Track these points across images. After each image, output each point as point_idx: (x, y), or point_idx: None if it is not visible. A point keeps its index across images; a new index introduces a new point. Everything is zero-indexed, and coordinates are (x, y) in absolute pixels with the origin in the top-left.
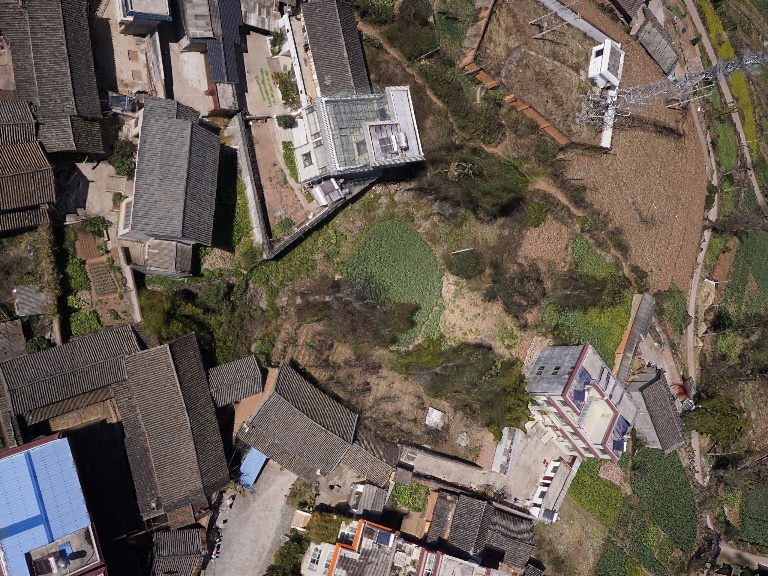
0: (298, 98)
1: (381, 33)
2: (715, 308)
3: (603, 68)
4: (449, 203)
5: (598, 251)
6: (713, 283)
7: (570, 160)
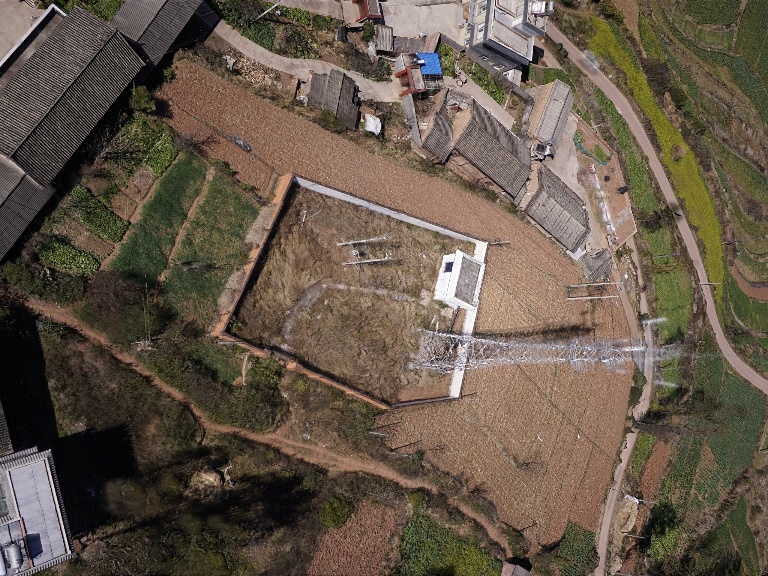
0: None
1: (75, 311)
2: (645, 517)
3: (449, 294)
4: (155, 571)
5: (446, 525)
6: (636, 500)
7: (398, 422)
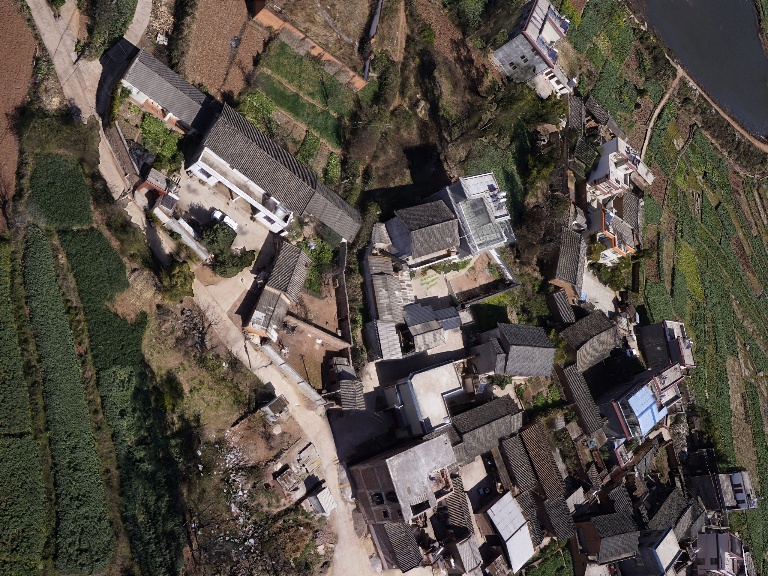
0: (449, 261)
1: None
2: None
3: None
4: None
5: None
6: None
7: None
